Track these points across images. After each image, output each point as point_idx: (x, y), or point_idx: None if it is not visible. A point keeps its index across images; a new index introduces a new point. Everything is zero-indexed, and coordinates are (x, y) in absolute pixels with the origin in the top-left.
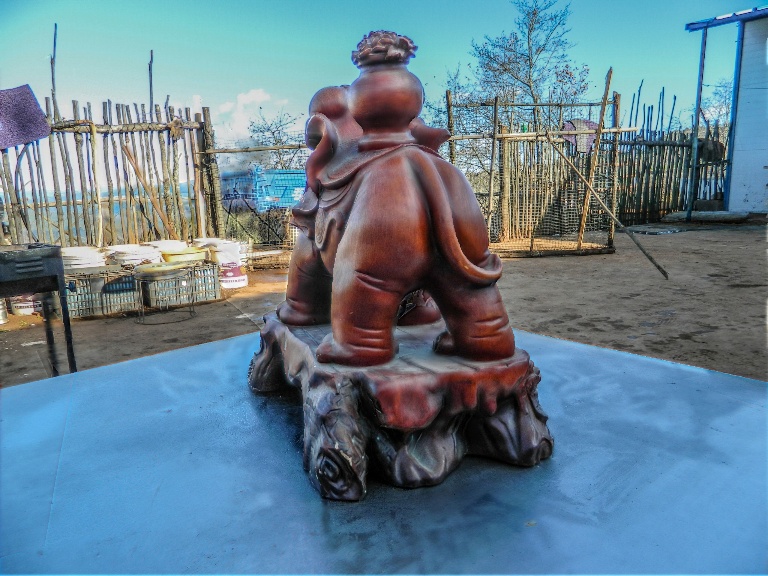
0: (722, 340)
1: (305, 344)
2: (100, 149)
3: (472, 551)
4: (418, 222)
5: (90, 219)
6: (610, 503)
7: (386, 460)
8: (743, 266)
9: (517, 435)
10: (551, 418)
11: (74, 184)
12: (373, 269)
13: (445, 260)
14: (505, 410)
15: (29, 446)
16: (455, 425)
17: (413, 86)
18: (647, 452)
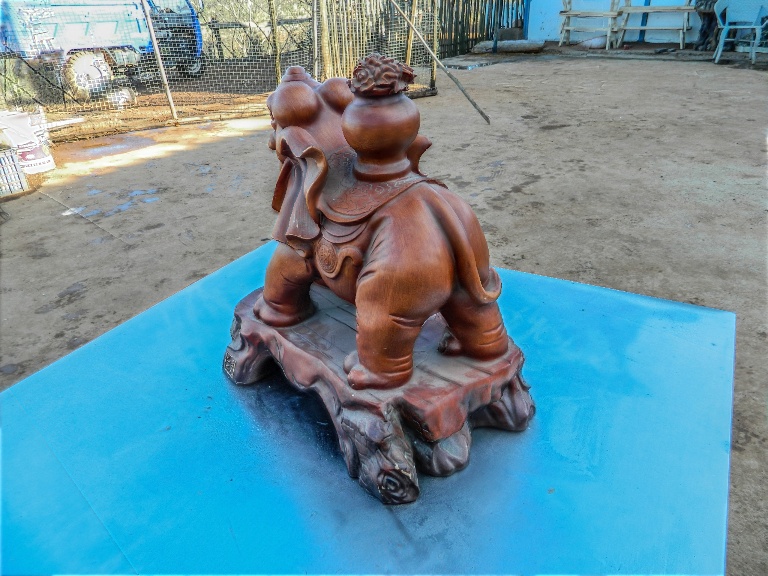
0: (546, 190)
1: (315, 358)
2: None
3: (525, 529)
4: (448, 269)
5: None
6: (593, 455)
7: (425, 459)
8: (548, 104)
9: (513, 409)
10: None
11: None
12: (408, 313)
13: (466, 294)
14: (503, 392)
15: (49, 509)
16: (470, 415)
17: (415, 118)
18: (596, 395)
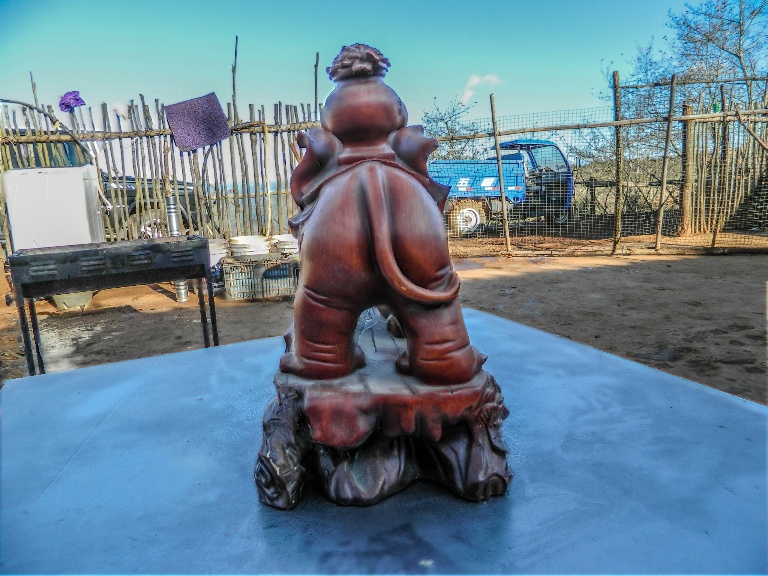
0: None
1: (294, 350)
2: (271, 147)
3: None
4: (355, 241)
5: (261, 211)
6: (530, 557)
7: (324, 474)
8: None
9: (466, 466)
10: (540, 451)
11: (249, 179)
12: (316, 286)
13: (385, 280)
14: (457, 438)
15: (82, 418)
16: (399, 448)
17: (380, 99)
18: (620, 505)
